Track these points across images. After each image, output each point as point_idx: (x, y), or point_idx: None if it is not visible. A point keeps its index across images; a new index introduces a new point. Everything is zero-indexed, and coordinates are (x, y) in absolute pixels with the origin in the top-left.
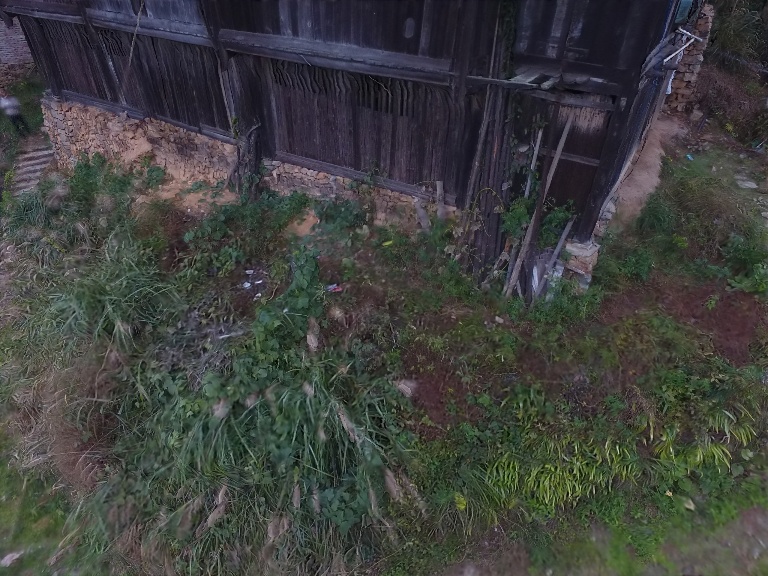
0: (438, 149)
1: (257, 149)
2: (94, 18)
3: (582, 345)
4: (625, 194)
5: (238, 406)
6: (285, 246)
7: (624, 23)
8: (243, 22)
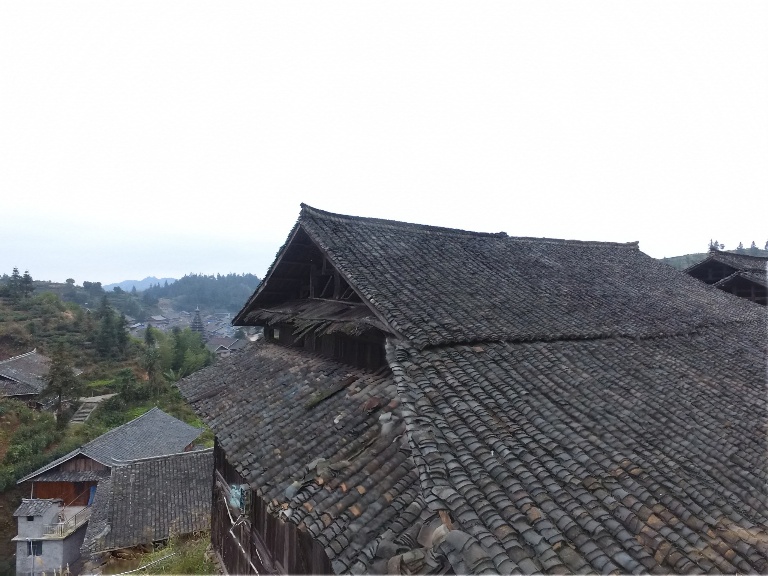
0: None
1: None
2: None
3: (189, 563)
4: None
5: None
6: None
7: None
8: None
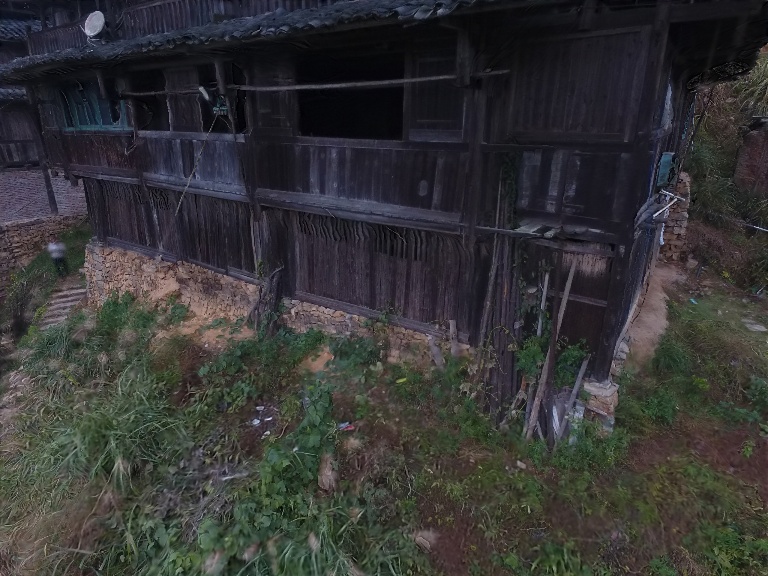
0: (450, 290)
1: (278, 289)
2: (149, 180)
3: (615, 495)
4: (636, 335)
5: (234, 562)
6: (298, 382)
7: (613, 185)
8: (278, 183)
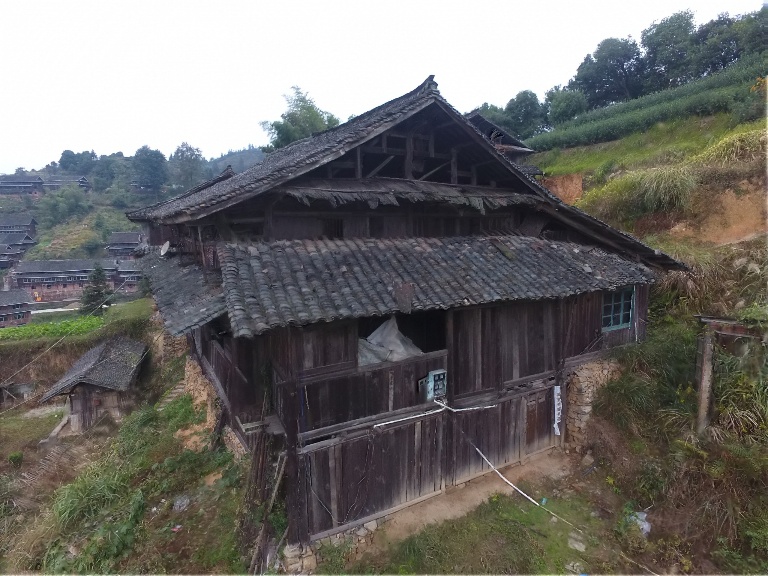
0: None
1: (223, 418)
2: None
3: None
4: (400, 518)
5: None
6: None
7: None
8: (206, 356)
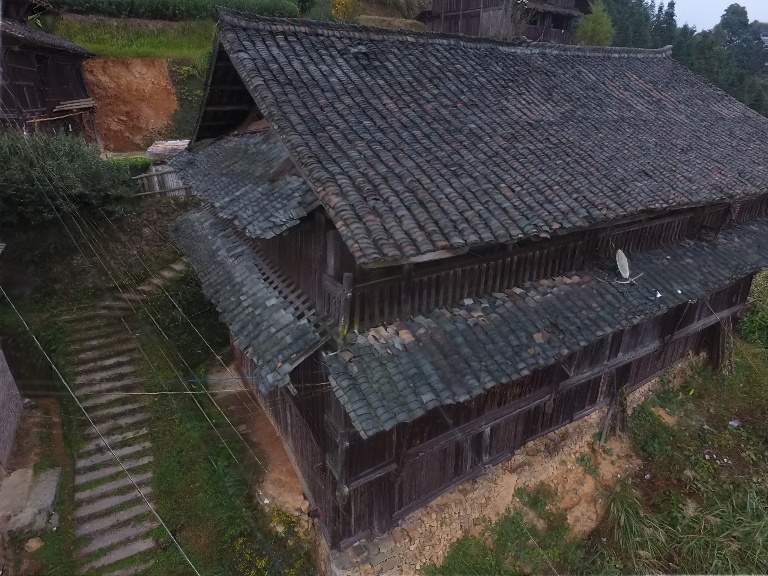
0: None
1: None
2: (565, 387)
3: None
4: None
5: None
6: None
7: None
8: None
